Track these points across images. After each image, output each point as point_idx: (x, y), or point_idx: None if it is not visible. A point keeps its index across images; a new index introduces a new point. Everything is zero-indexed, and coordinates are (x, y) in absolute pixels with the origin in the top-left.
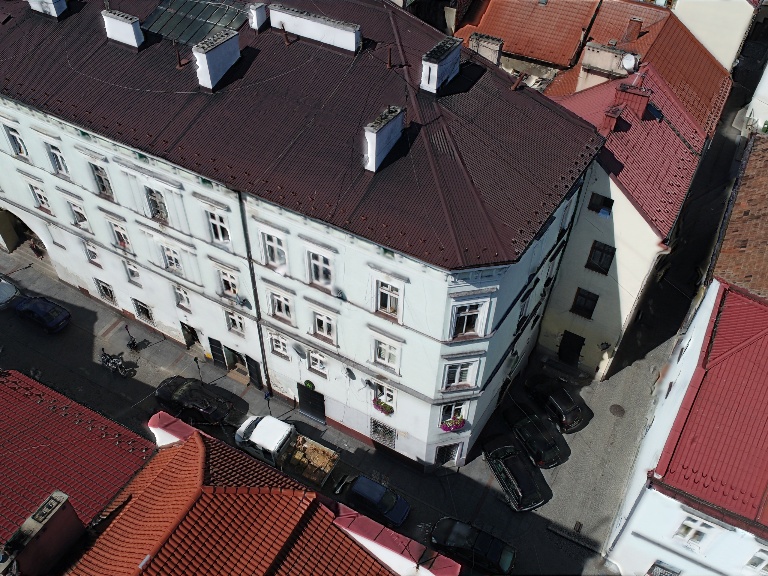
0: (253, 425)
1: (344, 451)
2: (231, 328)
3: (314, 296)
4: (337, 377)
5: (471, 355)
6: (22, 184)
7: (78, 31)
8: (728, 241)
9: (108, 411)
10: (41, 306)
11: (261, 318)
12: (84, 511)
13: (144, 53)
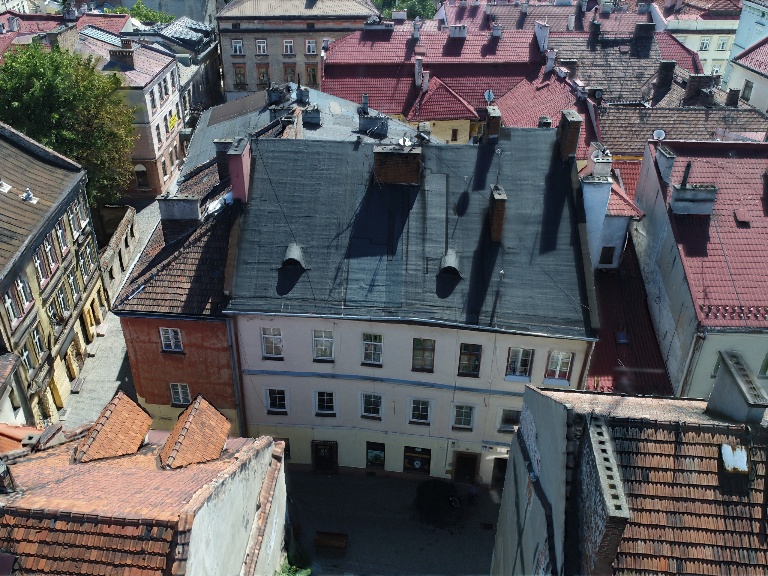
0: None
1: None
2: None
3: None
4: None
5: None
6: None
7: None
8: None
9: None
10: None
11: None
12: None
13: None
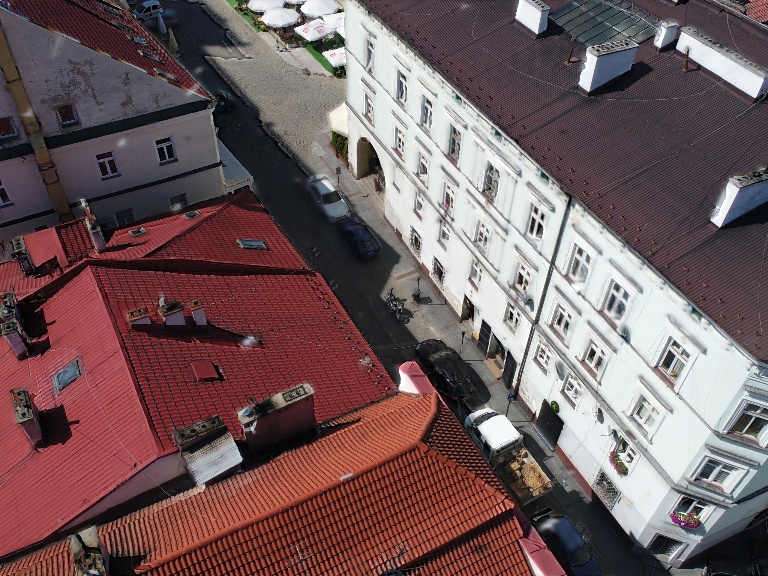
0: (486, 416)
1: (559, 485)
2: (506, 320)
3: (598, 324)
4: (585, 412)
5: (740, 460)
6: (391, 125)
7: (492, 6)
8: None
9: (373, 343)
10: (361, 232)
11: (538, 323)
12: (320, 412)
13: (541, 41)
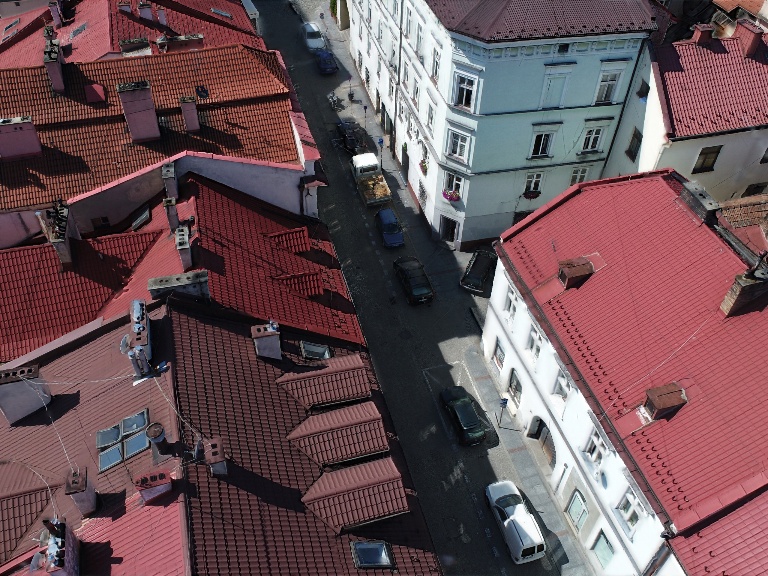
0: None
1: (402, 203)
2: (391, 95)
3: None
4: None
5: (464, 126)
6: None
7: None
8: (767, 194)
9: (310, 119)
10: (326, 55)
11: None
12: None
13: None
